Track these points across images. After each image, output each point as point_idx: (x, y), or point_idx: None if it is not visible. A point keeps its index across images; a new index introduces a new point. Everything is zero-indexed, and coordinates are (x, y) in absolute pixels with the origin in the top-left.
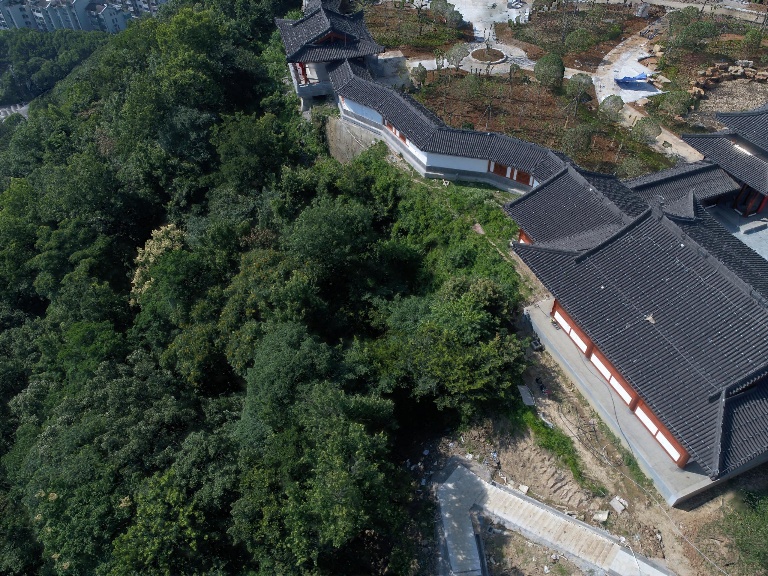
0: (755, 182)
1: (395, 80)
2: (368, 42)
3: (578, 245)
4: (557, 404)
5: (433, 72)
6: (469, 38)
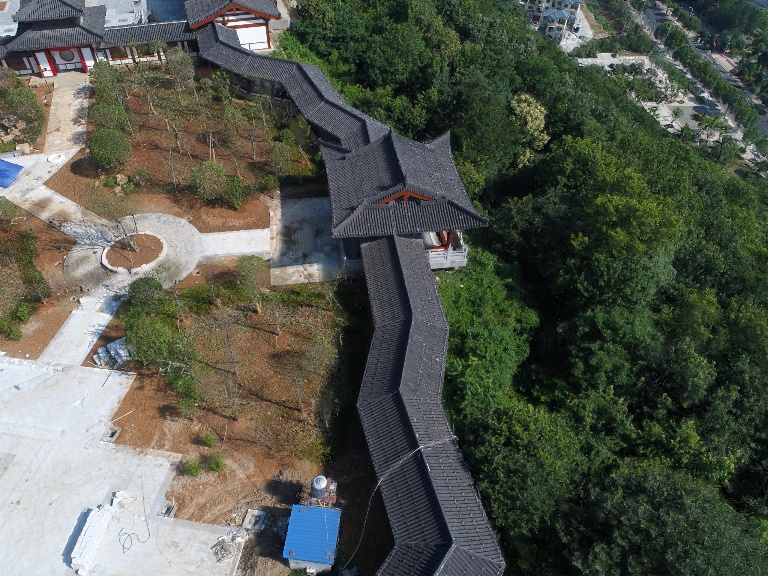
0: (101, 14)
1: (303, 213)
2: (340, 147)
3: None
4: (294, 7)
5: (252, 186)
6: (128, 308)
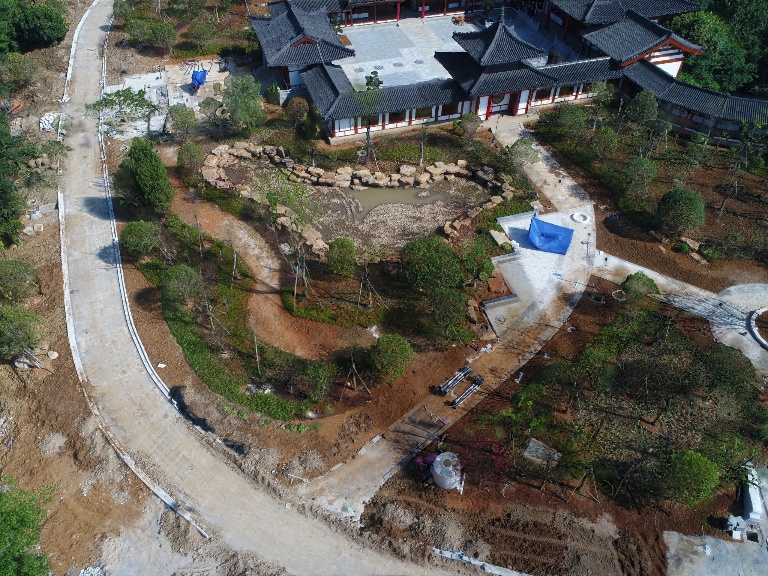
0: None
1: None
2: None
3: (660, 6)
4: None
5: None
6: None
